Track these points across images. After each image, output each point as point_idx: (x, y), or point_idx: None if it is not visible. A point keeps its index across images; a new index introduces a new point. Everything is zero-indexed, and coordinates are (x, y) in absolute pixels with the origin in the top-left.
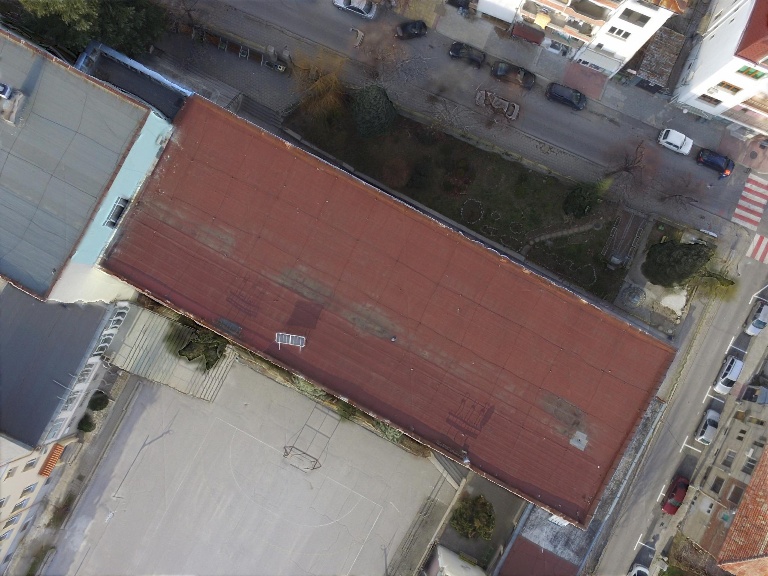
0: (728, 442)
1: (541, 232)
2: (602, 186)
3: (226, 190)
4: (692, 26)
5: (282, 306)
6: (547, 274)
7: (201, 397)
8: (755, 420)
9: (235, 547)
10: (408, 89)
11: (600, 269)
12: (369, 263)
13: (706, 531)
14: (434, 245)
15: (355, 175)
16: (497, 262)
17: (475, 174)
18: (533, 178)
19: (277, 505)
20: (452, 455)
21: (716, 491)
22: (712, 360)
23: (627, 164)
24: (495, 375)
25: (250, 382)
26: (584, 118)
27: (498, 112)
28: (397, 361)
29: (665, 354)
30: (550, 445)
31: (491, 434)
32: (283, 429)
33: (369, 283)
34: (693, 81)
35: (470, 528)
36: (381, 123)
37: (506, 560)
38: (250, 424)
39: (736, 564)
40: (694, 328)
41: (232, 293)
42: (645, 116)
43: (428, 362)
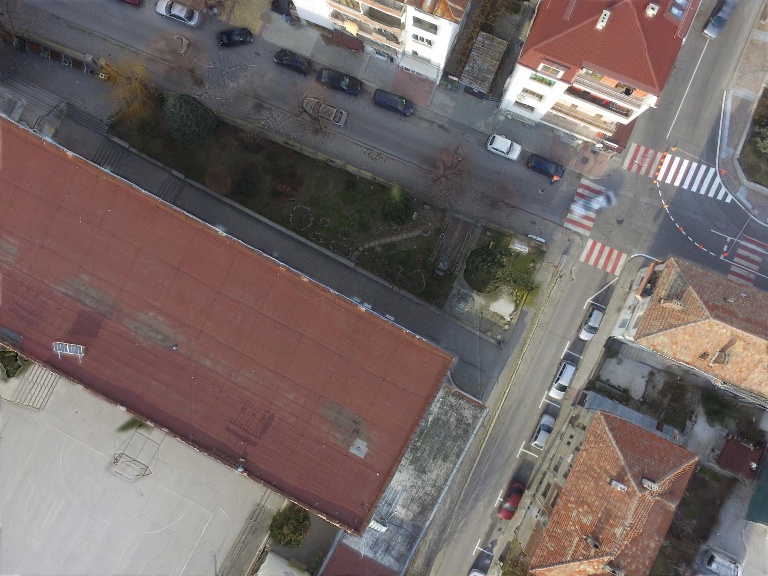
0: (561, 447)
1: (370, 238)
2: (430, 192)
3: (10, 199)
4: (518, 32)
5: (65, 315)
6: (377, 280)
7: (29, 404)
8: (581, 425)
9: (65, 554)
10: (233, 96)
11: (429, 275)
12: (151, 272)
13: (531, 536)
14: (215, 253)
15: (186, 182)
16: (276, 270)
17: (302, 181)
18: (361, 184)
19: (107, 512)
20: (229, 463)
21: (545, 496)
22: (548, 365)
23: (445, 170)
24: (276, 383)
25: (80, 389)
26: (413, 124)
27: (315, 119)
28: (178, 369)
29: (443, 361)
30: (330, 452)
31: (271, 442)
32: (113, 436)
33: (151, 291)
34: (508, 87)
35: (279, 535)
36: (195, 131)
37: (327, 566)
38: (80, 431)
39: (546, 570)
40: (526, 333)
41: (15, 302)
42: (474, 122)
43: (209, 370)
